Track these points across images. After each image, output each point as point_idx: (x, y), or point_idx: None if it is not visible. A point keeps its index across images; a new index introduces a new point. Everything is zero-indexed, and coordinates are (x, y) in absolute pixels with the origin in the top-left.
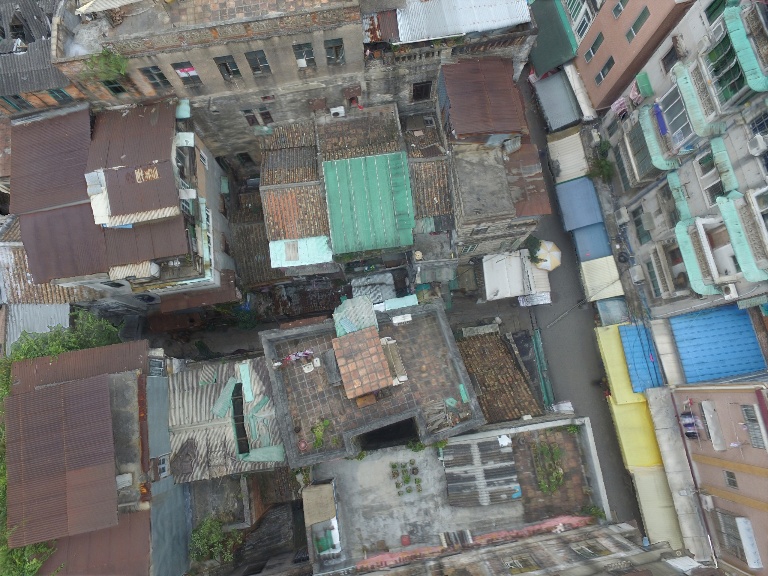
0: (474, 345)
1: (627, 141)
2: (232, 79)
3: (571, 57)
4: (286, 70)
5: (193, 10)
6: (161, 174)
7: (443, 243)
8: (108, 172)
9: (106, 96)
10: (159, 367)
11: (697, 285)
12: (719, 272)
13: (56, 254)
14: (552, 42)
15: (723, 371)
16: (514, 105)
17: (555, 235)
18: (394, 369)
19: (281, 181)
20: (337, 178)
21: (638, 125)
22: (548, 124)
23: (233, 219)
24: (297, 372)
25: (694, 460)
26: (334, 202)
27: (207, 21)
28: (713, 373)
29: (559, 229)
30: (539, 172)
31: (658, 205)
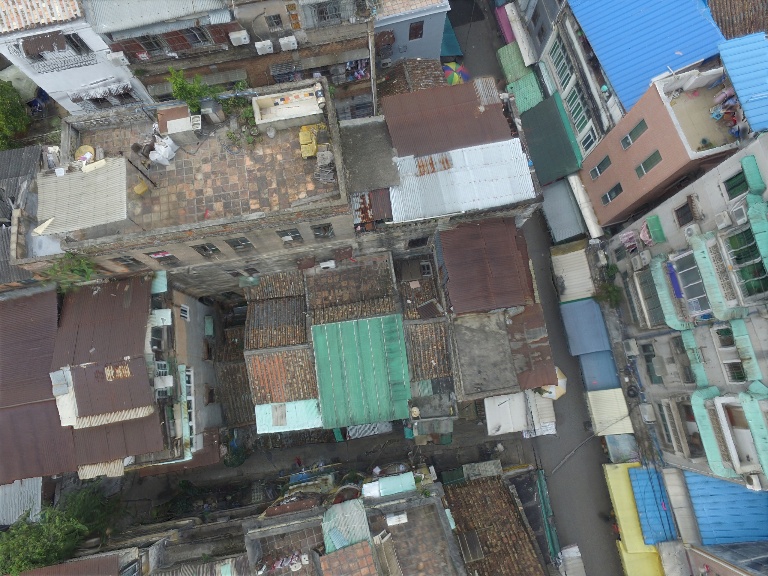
0: (475, 492)
1: (637, 282)
2: (212, 254)
3: (575, 169)
4: (270, 245)
5: (167, 198)
6: (133, 371)
7: (441, 394)
8: (75, 370)
9: (75, 276)
10: (133, 574)
11: (716, 467)
12: (740, 459)
13: (20, 453)
14: (555, 151)
15: (742, 535)
16: (517, 274)
17: (559, 349)
18: (389, 573)
19: (267, 344)
20: (327, 344)
21: (649, 272)
22: (551, 234)
23: (218, 357)
24: (283, 570)
25: None
26: (324, 370)
27: (182, 212)
28: (731, 536)
29: (563, 342)
30: (544, 336)
31: (671, 353)
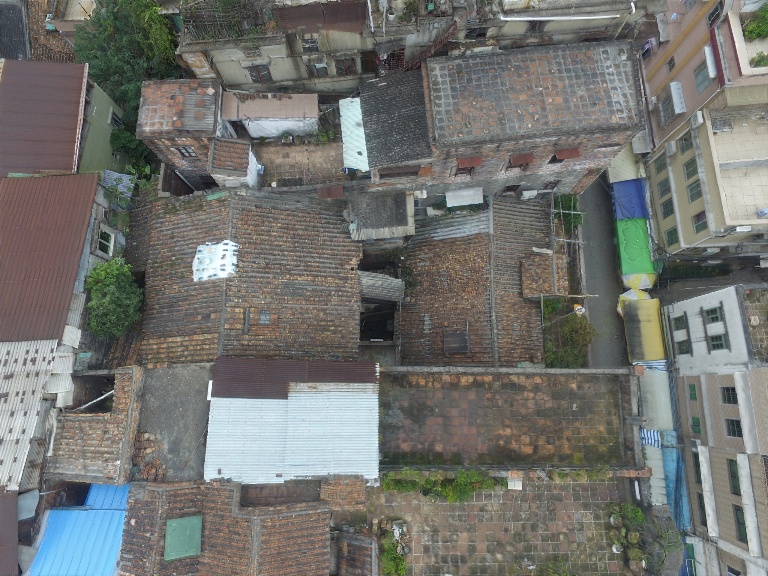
0: None
1: None
2: None
3: None
4: None
5: None
6: None
7: None
8: None
9: None
10: None
11: None
12: None
13: None
14: None
15: None
16: None
17: None
18: None
19: None
20: None
21: None
22: None
23: None
24: None
25: (647, 81)
26: None
27: None
28: None
29: None
30: None
31: None
